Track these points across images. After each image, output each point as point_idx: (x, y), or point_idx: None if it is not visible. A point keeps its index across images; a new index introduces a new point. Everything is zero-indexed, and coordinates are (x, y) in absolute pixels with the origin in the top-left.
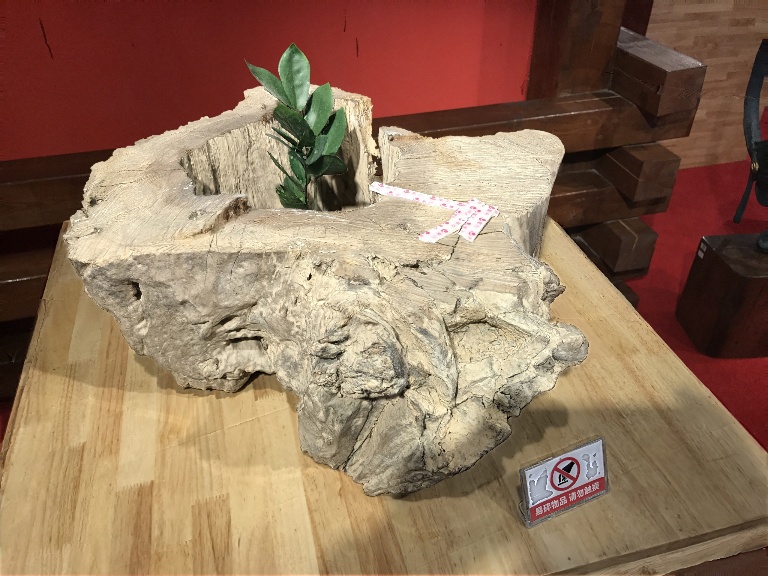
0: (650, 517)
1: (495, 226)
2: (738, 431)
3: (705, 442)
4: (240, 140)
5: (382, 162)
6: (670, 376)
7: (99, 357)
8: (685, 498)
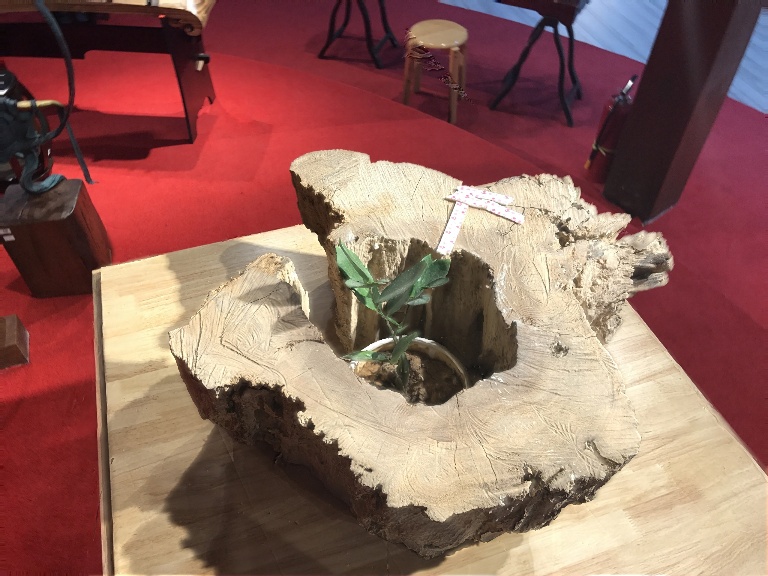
0: None
1: None
2: None
3: None
4: None
5: None
6: None
7: None
8: None
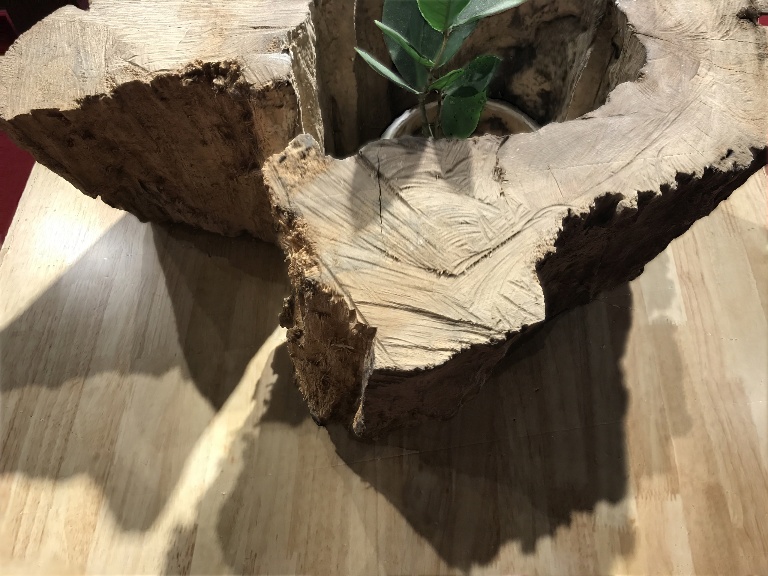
0: None
1: None
2: None
3: None
4: None
5: None
6: None
7: (704, 236)
8: None
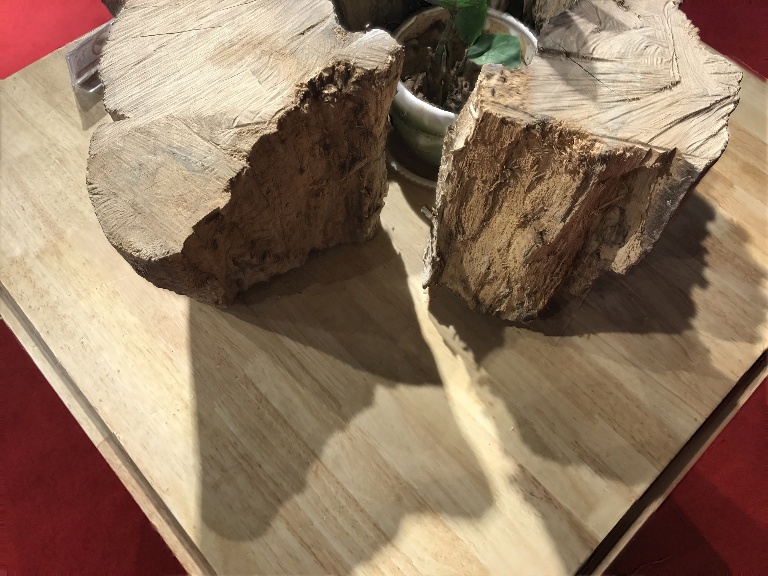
0: (39, 79)
1: None
2: None
3: None
4: None
5: None
6: (1, 233)
7: None
8: (7, 103)
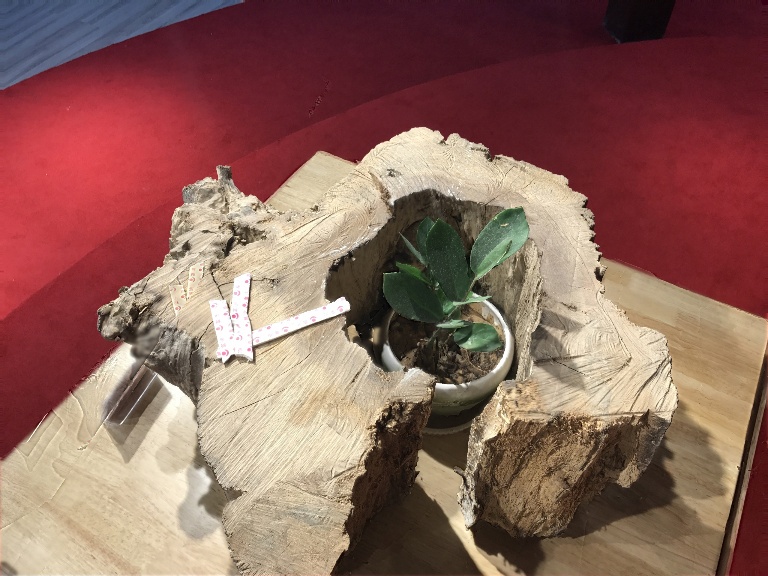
0: None
1: (210, 340)
2: (6, 563)
3: (35, 524)
4: None
5: None
6: None
7: None
8: None
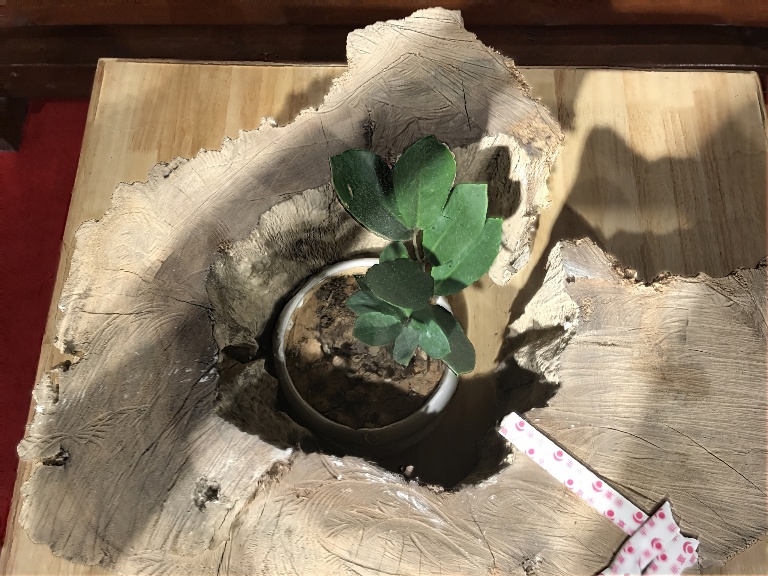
0: None
1: None
2: None
3: None
4: (318, 198)
5: (545, 281)
6: None
7: None
8: None
